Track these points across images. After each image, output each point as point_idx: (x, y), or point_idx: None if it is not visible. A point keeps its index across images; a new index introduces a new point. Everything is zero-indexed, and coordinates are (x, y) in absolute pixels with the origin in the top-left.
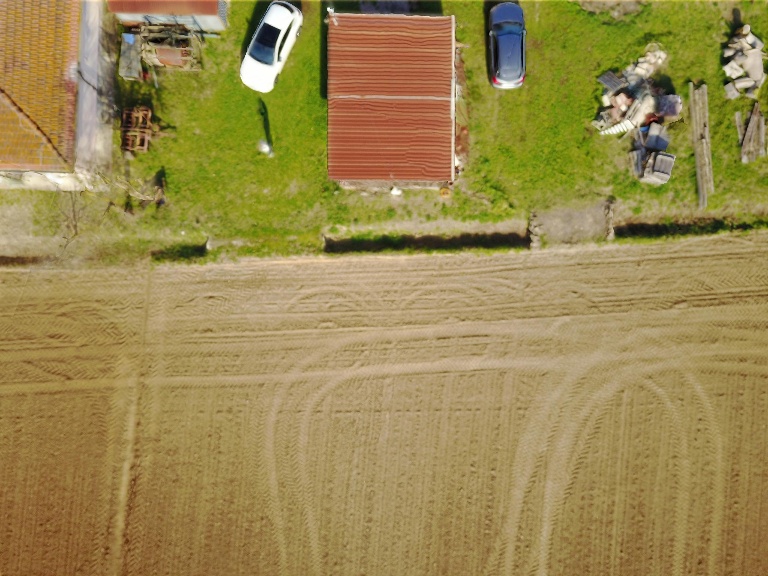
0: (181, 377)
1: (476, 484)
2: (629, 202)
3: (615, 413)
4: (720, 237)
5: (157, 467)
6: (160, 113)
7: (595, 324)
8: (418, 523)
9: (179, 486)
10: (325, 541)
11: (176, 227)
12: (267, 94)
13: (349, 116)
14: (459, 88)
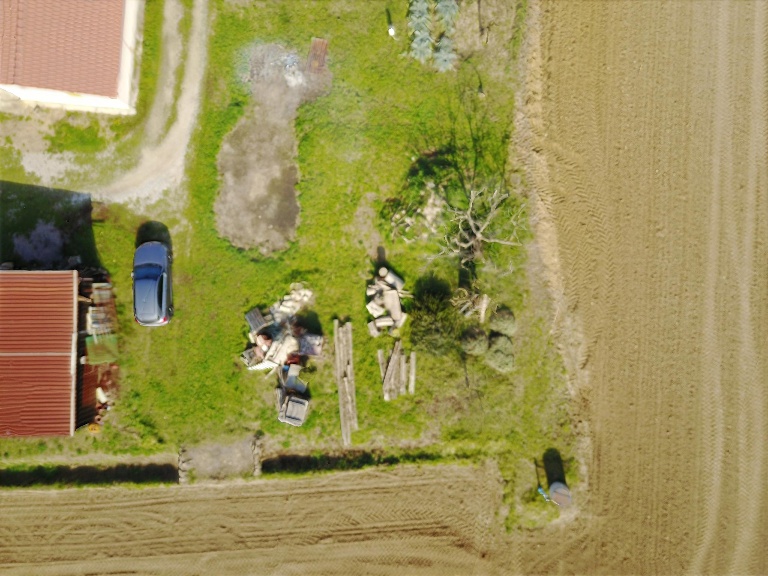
0: None
1: None
2: (278, 436)
3: None
4: (366, 471)
5: None
6: None
7: (242, 560)
8: None
9: None
10: None
11: None
12: None
13: None
14: (105, 326)
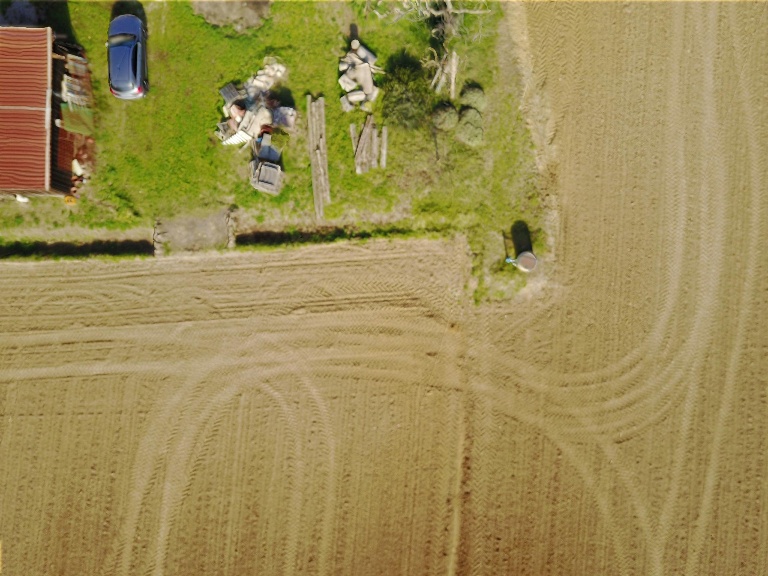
0: None
1: (96, 486)
2: (252, 210)
3: (233, 416)
4: (339, 245)
5: None
6: None
7: (216, 329)
8: (37, 525)
9: None
10: None
11: None
12: None
13: None
14: (80, 98)
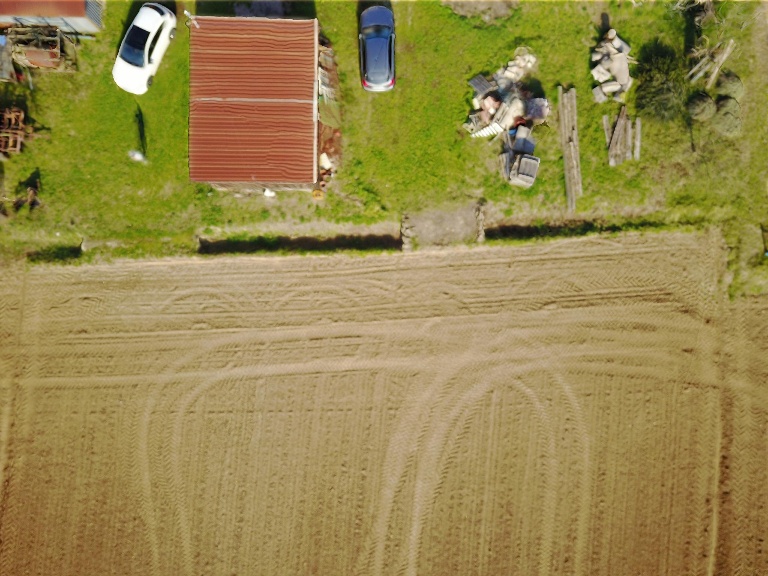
0: (55, 378)
1: (347, 484)
2: (500, 204)
3: (484, 413)
4: (589, 239)
5: (30, 468)
6: (35, 114)
7: (466, 325)
8: (289, 523)
9: (52, 487)
10: (197, 541)
11: (51, 228)
12: (141, 96)
13: (209, 118)
14: (330, 91)
